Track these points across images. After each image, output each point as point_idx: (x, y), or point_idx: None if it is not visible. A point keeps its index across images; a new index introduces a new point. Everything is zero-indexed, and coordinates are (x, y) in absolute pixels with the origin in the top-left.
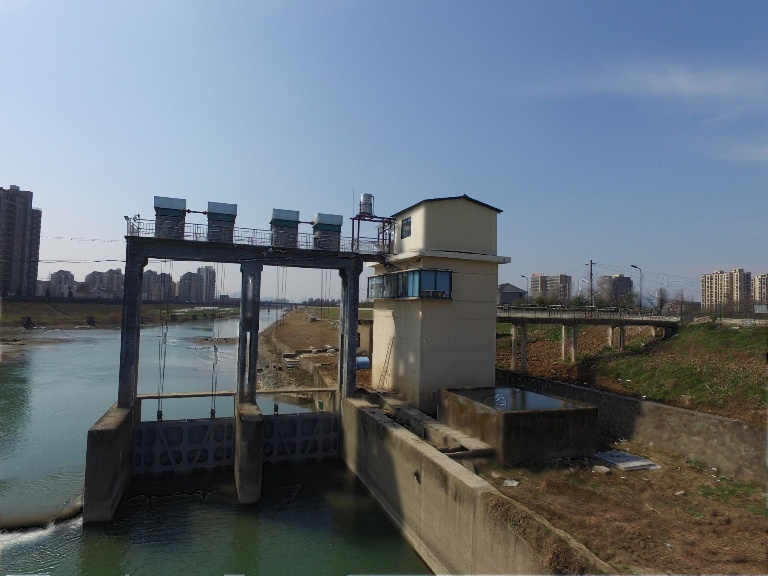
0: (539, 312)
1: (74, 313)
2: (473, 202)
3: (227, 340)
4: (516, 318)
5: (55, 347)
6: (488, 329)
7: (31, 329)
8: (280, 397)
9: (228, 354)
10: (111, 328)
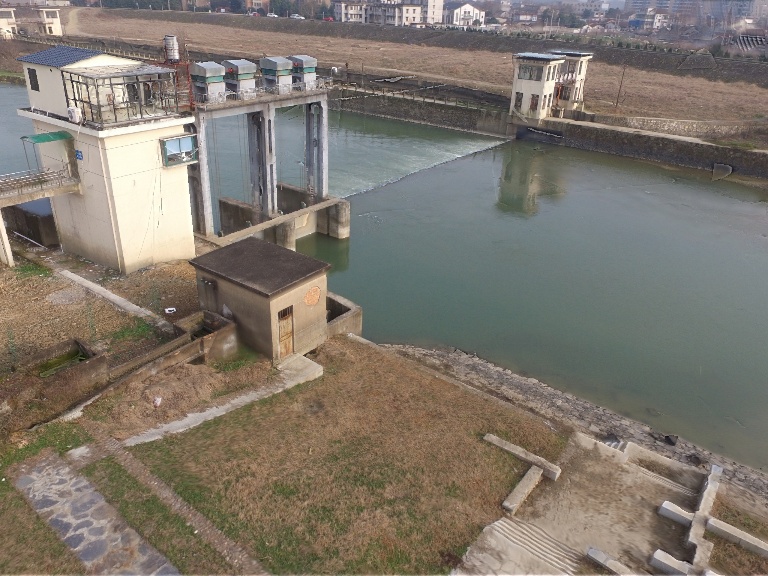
0: None
1: None
2: (50, 51)
3: None
4: None
5: None
6: None
7: None
8: (403, 342)
9: None
10: None
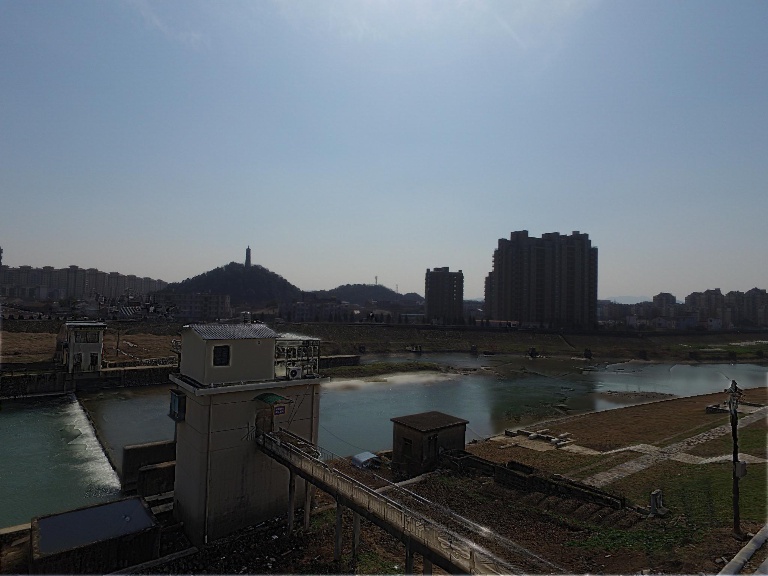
0: (303, 462)
1: (580, 345)
2: None
3: (639, 396)
4: (284, 460)
5: (478, 380)
6: (197, 459)
7: (536, 358)
8: None
9: (561, 415)
10: (610, 362)
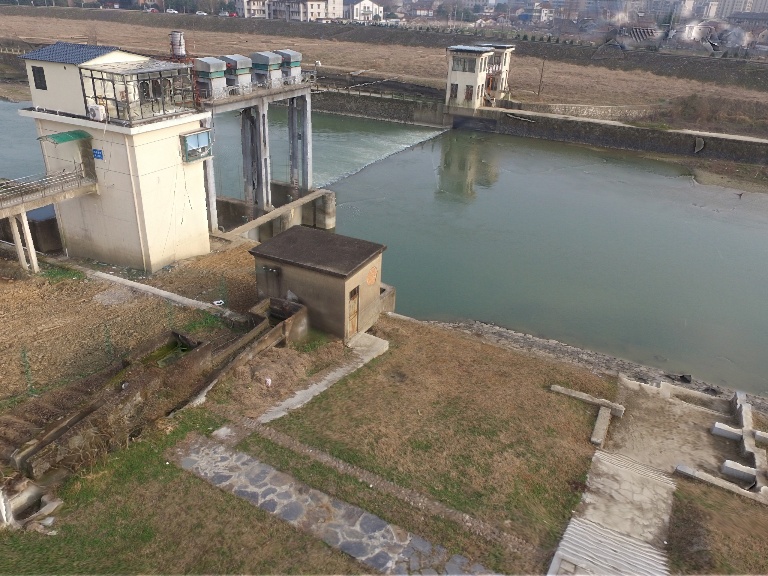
0: None
1: None
2: (50, 48)
3: None
4: None
5: None
6: None
7: None
8: None
9: None
10: None
